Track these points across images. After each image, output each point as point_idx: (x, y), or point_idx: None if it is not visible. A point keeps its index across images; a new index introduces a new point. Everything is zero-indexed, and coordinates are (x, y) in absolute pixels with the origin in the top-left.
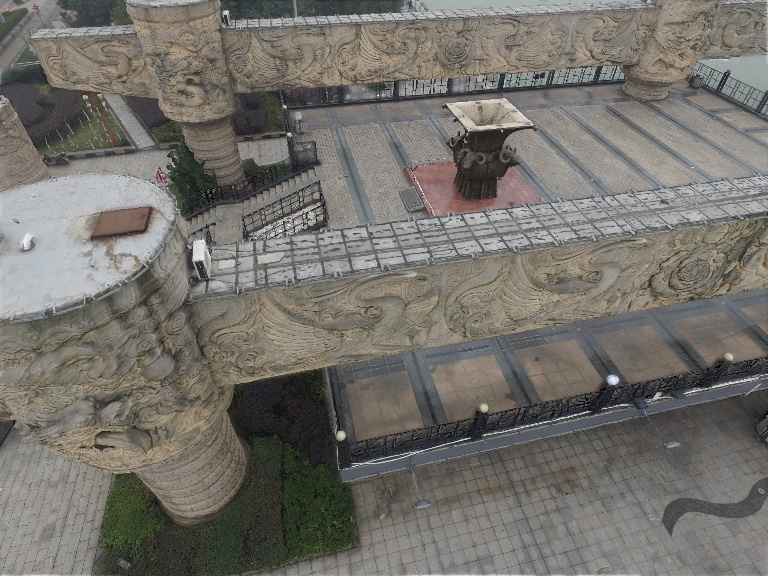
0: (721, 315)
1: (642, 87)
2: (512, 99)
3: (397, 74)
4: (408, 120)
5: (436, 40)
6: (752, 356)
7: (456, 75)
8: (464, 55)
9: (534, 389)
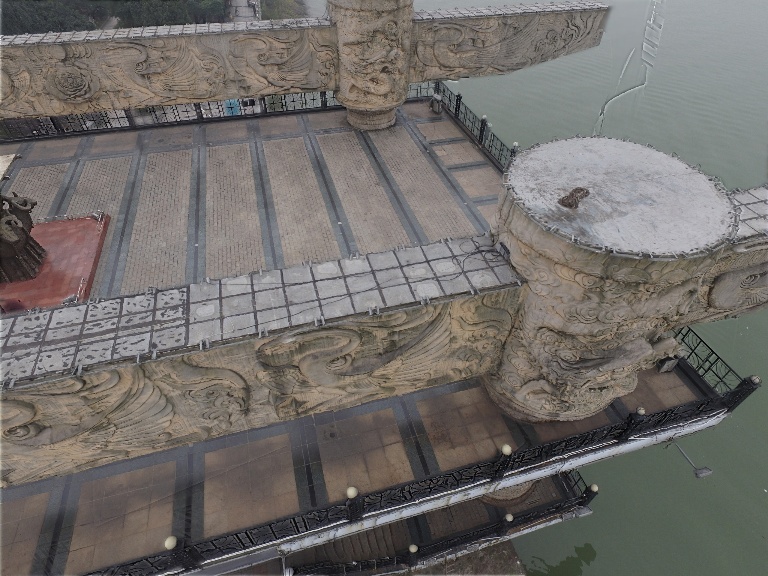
0: (167, 467)
1: (356, 115)
2: (206, 132)
3: (2, 112)
4: (48, 164)
5: (35, 70)
6: (145, 545)
7: (90, 110)
8: (84, 87)
9: None
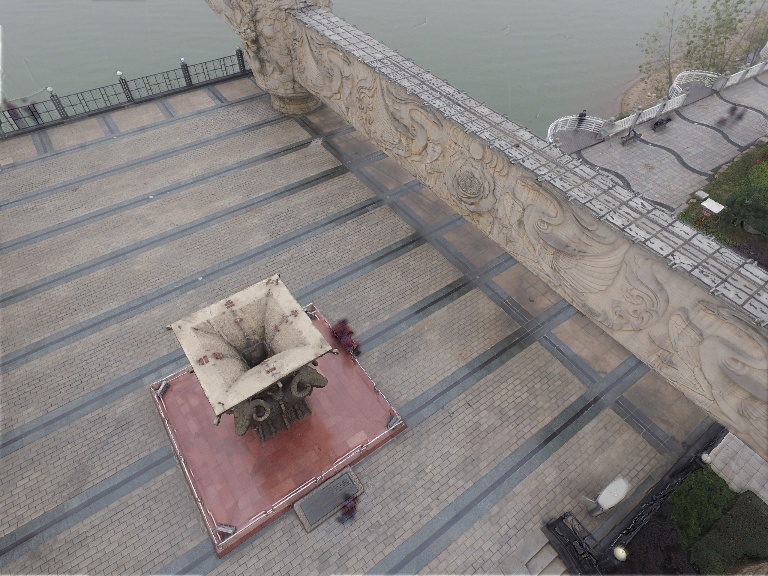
0: (404, 199)
1: None
2: None
3: None
4: None
5: None
6: None
7: None
8: None
9: (563, 299)
